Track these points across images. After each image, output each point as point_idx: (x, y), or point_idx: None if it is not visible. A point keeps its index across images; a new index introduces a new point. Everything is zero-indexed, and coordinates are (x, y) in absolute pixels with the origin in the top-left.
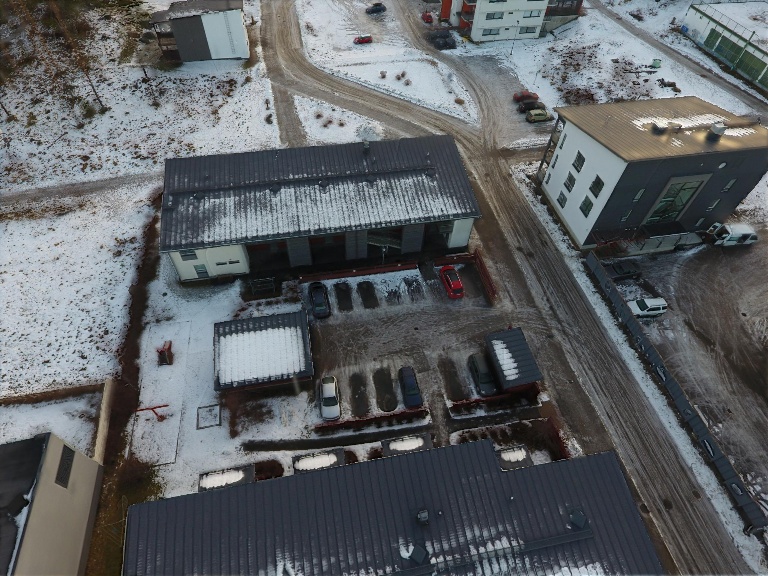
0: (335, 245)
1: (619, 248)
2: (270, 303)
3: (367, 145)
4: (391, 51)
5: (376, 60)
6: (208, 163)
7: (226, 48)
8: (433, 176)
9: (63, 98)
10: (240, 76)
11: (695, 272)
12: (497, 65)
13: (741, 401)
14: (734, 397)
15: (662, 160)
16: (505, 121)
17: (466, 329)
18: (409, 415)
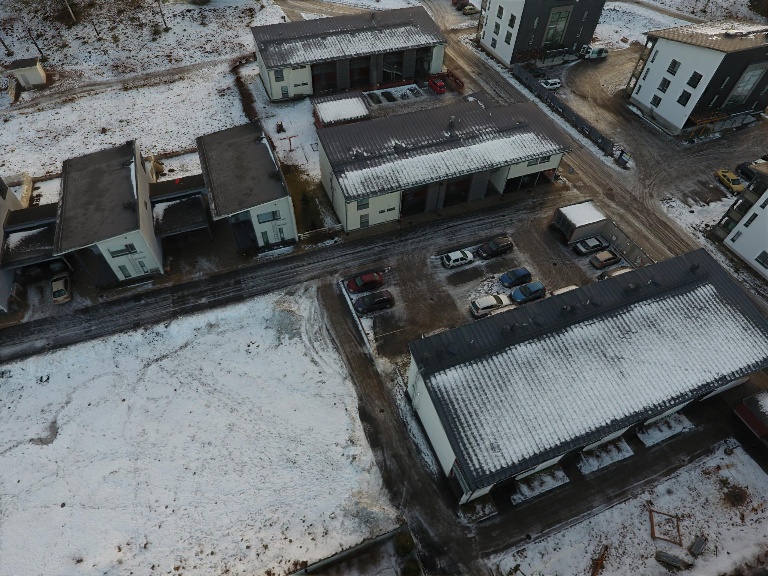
0: (361, 78)
1: (531, 64)
2: None
3: None
4: None
5: None
6: (278, 27)
7: None
8: (416, 26)
9: (132, 25)
10: (256, 5)
11: (575, 71)
12: None
13: (602, 116)
14: (599, 115)
15: None
16: (449, 16)
17: None
18: None
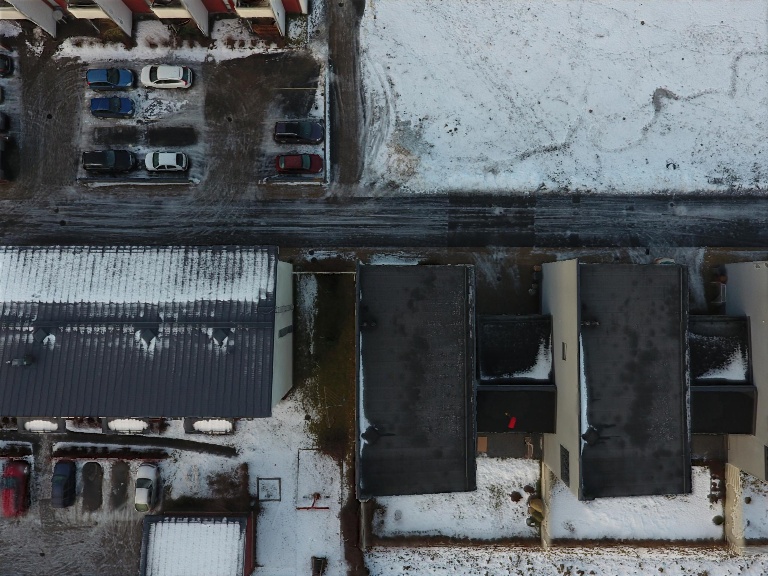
0: None
1: None
2: None
3: None
4: None
5: None
6: None
7: None
8: None
9: None
10: None
11: None
12: None
13: None
14: None
15: None
16: None
17: None
18: (71, 455)
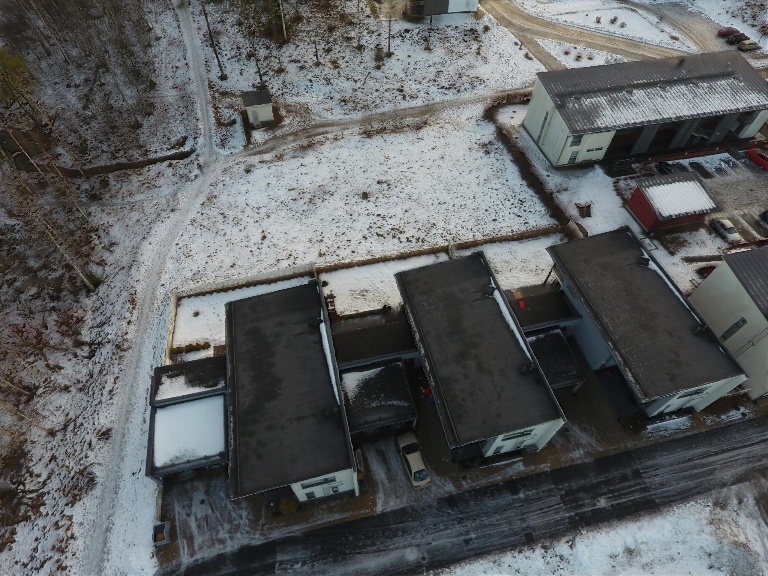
0: (653, 140)
1: None
2: (633, 178)
3: None
4: (589, 2)
5: (582, 9)
6: (569, 74)
7: (462, 2)
8: (739, 79)
9: (349, 47)
10: (477, 26)
11: None
12: (687, 9)
13: None
14: None
15: None
16: None
17: None
18: None
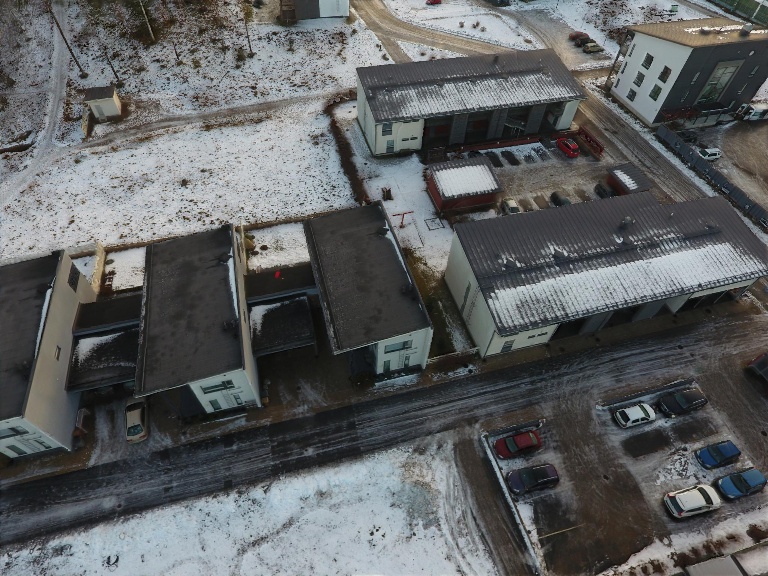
0: (475, 131)
1: (678, 124)
2: None
3: (497, 54)
4: (460, 9)
5: (451, 15)
6: (387, 69)
7: (333, 7)
8: (547, 74)
9: (214, 48)
10: (347, 29)
11: (733, 136)
12: (548, 16)
13: None
14: None
15: (715, 47)
16: (568, 53)
17: (586, 174)
18: None
